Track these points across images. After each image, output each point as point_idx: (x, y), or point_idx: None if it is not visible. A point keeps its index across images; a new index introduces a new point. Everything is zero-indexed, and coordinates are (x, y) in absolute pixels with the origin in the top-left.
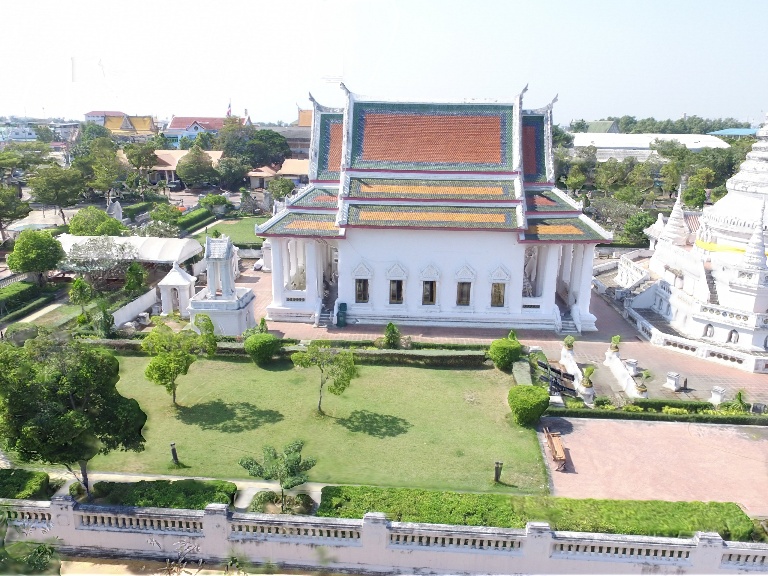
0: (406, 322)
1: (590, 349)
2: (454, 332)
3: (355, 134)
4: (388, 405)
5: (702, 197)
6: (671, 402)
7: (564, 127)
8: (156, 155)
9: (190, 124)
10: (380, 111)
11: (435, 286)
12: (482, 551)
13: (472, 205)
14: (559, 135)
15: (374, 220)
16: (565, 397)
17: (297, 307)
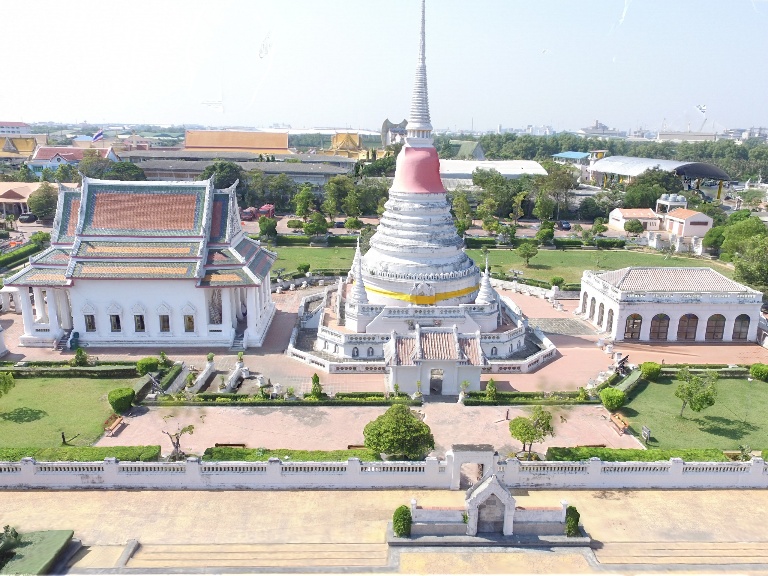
0: (124, 345)
1: None
2: (155, 351)
3: (88, 208)
4: (44, 404)
5: (461, 228)
6: (222, 395)
7: None
8: None
9: (53, 155)
10: (108, 191)
11: (143, 318)
12: (1, 473)
13: (166, 261)
14: None
15: (92, 273)
16: (159, 394)
17: (43, 336)
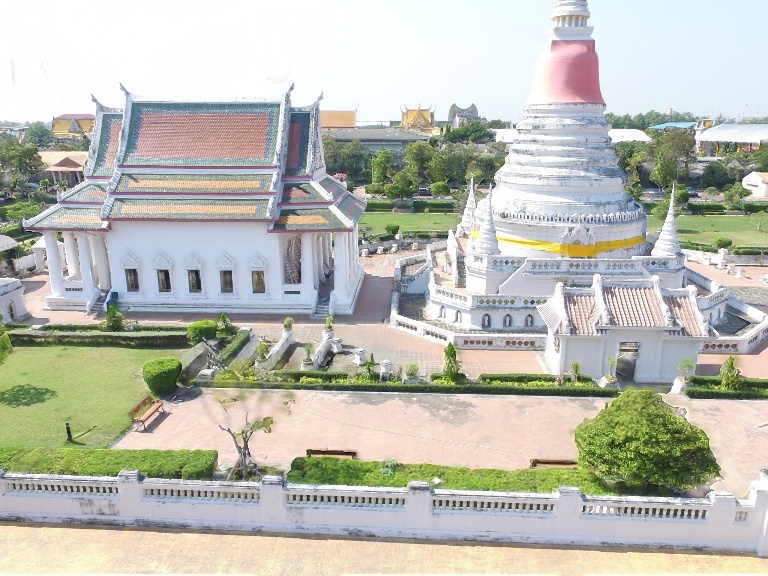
0: (175, 309)
1: None
2: (214, 317)
3: (131, 132)
4: (55, 380)
5: None
6: (309, 373)
7: (512, 123)
8: None
9: None
10: (157, 110)
11: (199, 275)
12: None
13: (229, 198)
14: (479, 131)
15: (134, 213)
16: (217, 370)
17: (74, 296)
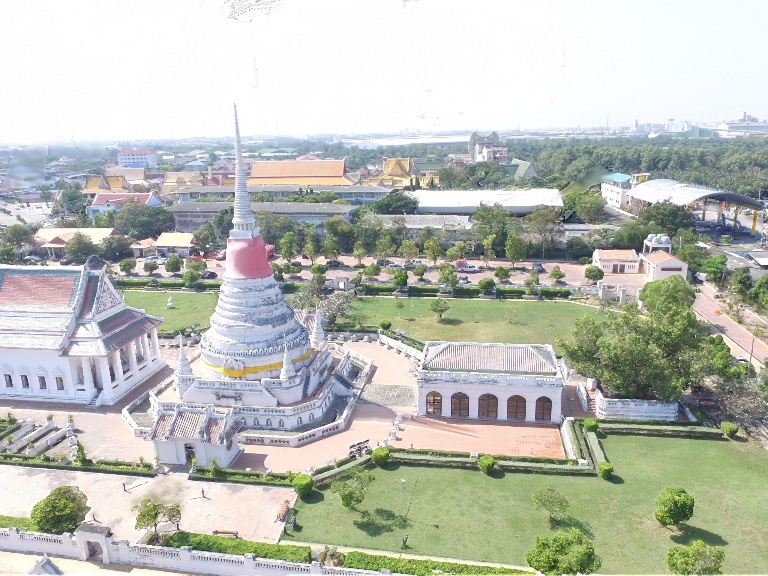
0: (15, 398)
1: (83, 418)
2: (32, 405)
3: None
4: None
5: (403, 277)
6: (17, 455)
7: (483, 170)
8: (14, 253)
9: None
10: (13, 274)
11: (28, 378)
12: None
13: (42, 333)
14: (401, 201)
15: None
16: None
17: None
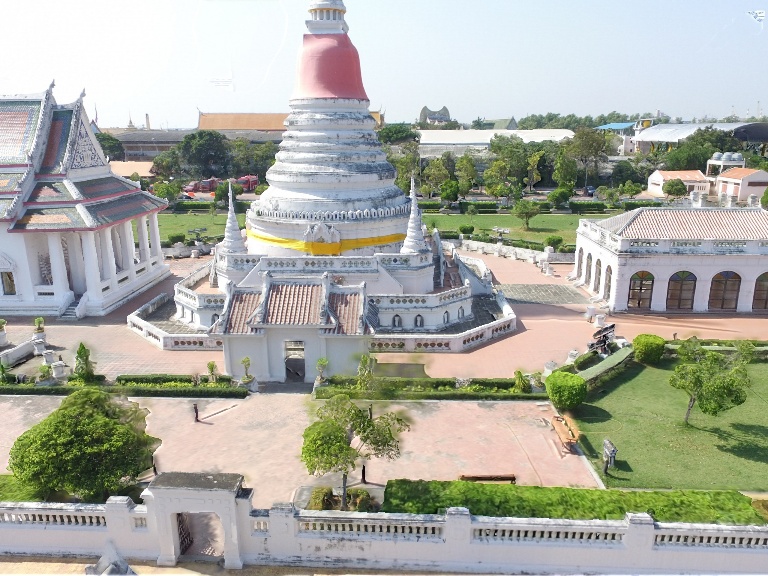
0: None
1: (57, 332)
2: None
3: None
4: None
5: (454, 189)
6: None
7: (462, 125)
8: None
9: None
10: None
11: None
12: None
13: None
14: (402, 132)
15: None
16: None
17: None
